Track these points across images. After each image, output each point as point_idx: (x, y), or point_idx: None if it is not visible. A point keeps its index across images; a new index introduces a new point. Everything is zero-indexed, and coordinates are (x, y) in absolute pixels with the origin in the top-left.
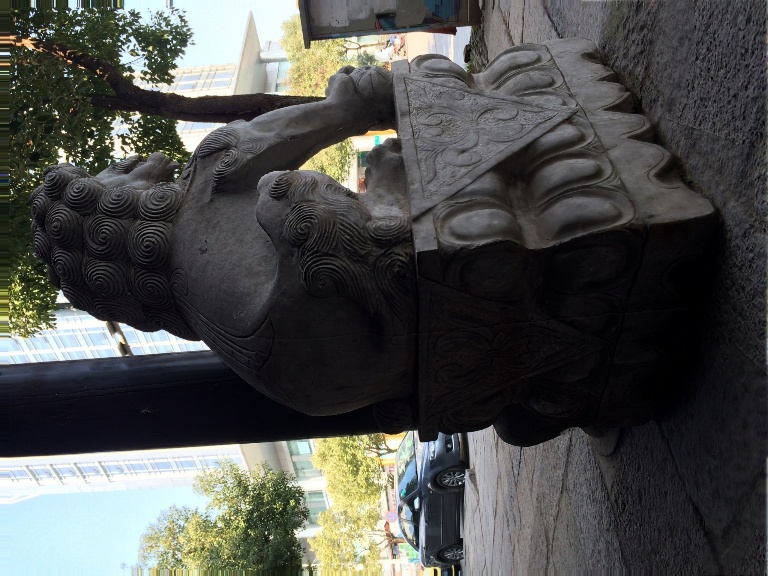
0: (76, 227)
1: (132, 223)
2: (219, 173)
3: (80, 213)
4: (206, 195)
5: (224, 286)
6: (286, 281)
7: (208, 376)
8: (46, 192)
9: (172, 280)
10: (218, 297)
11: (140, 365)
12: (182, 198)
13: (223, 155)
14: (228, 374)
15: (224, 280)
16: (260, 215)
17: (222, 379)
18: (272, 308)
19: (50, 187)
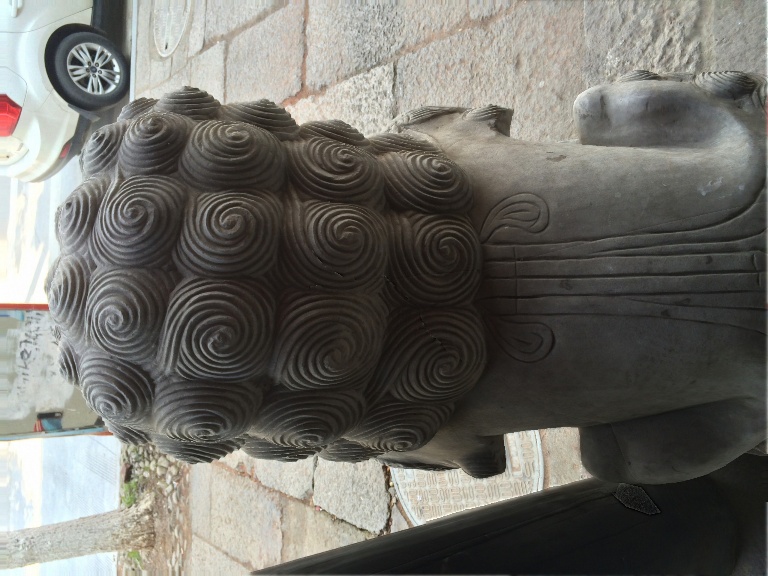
0: (277, 147)
1: (378, 156)
2: (496, 107)
3: (275, 133)
4: (481, 134)
5: (650, 167)
6: (759, 127)
7: (417, 552)
8: (181, 105)
9: (491, 224)
10: (650, 181)
11: (258, 572)
12: (433, 144)
13: (461, 114)
14: (445, 544)
15: (642, 163)
16: (654, 87)
17: (446, 551)
18: (767, 156)
19: (193, 97)
